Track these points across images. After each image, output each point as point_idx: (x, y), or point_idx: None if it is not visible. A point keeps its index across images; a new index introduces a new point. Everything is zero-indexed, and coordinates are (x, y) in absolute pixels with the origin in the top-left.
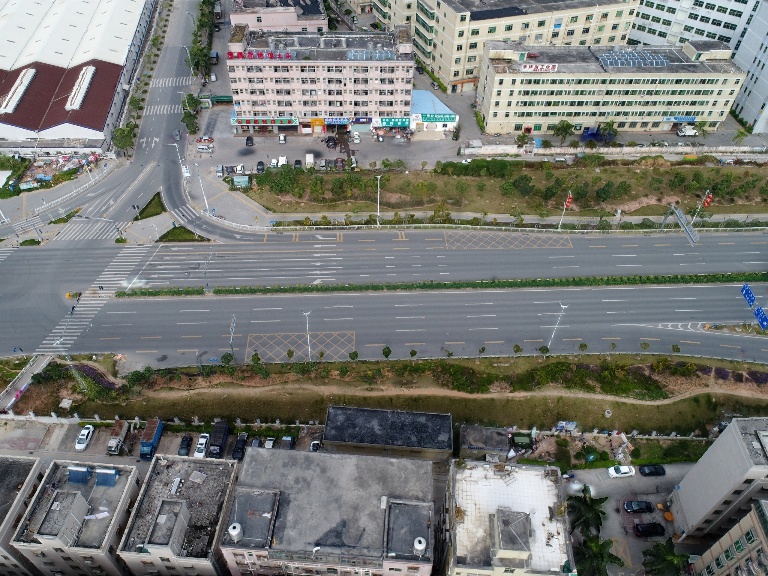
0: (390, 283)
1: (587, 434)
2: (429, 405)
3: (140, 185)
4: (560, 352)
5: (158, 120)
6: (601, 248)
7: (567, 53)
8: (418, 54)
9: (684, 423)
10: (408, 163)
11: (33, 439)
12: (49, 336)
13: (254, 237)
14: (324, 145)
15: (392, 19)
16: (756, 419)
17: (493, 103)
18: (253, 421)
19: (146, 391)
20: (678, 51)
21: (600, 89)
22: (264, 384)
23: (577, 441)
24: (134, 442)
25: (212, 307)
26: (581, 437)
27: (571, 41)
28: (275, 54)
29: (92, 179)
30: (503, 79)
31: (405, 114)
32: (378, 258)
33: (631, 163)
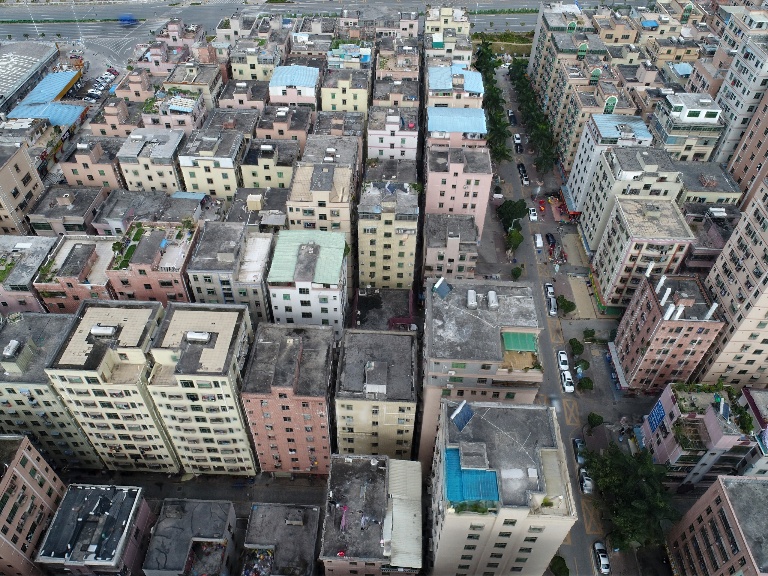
0: None
1: None
2: None
3: None
4: None
5: None
6: (508, 3)
7: None
8: None
9: None
10: None
11: None
12: None
13: (317, 2)
14: None
15: None
16: None
17: None
18: None
19: None
20: None
21: None
22: None
23: None
24: None
25: None
26: None
27: None
28: None
29: None
30: None
31: None
32: None
33: None
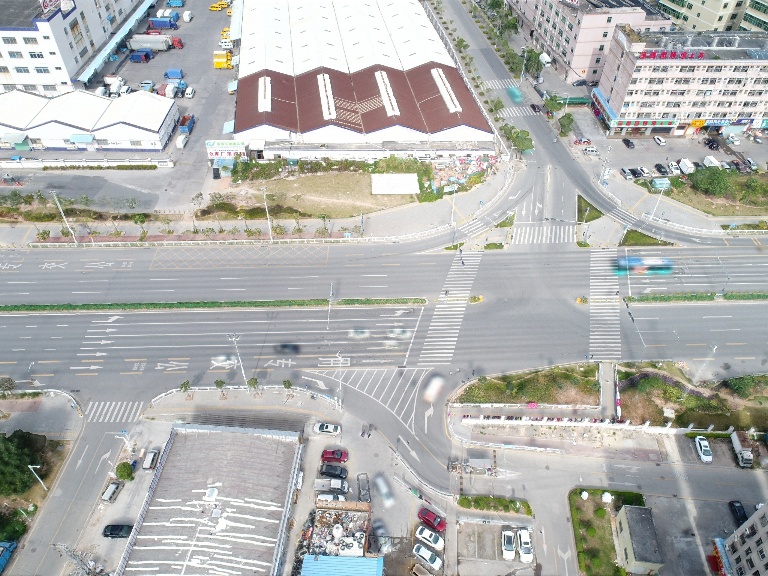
0: None
1: None
2: None
3: (553, 188)
4: None
5: (518, 122)
6: None
7: None
8: None
9: None
10: None
11: (650, 450)
12: (591, 342)
13: (714, 241)
14: (706, 147)
15: (690, 19)
16: None
17: None
18: None
19: (740, 401)
20: None
21: None
22: None
23: None
24: None
25: (732, 313)
26: None
27: None
28: (678, 54)
29: (507, 182)
30: None
31: None
32: None
33: None
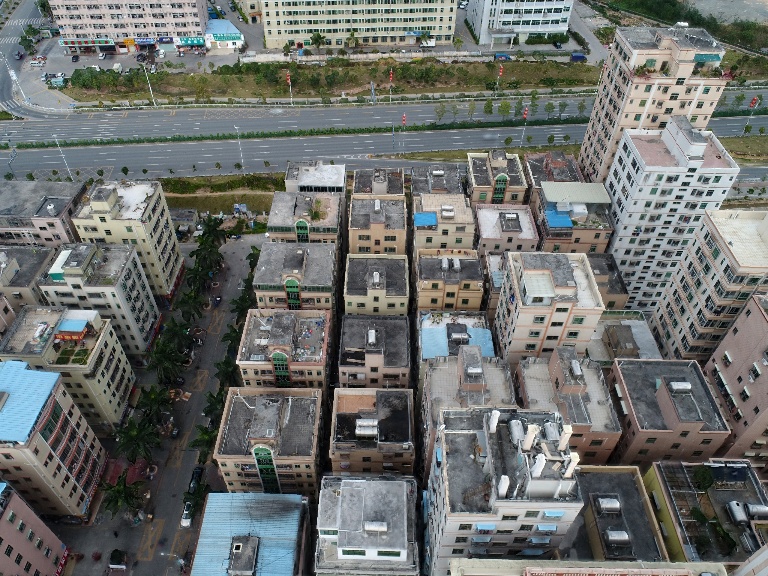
0: (148, 137)
1: (259, 216)
2: None
3: None
4: None
5: (5, 47)
6: (320, 116)
7: None
8: None
9: None
10: (197, 69)
11: None
12: None
13: (59, 116)
14: (135, 60)
15: None
16: (303, 162)
17: (265, 22)
18: None
19: None
20: None
21: (347, 9)
22: None
23: (252, 221)
24: None
25: None
26: (256, 218)
27: None
28: None
29: None
30: (267, 2)
31: (198, 34)
32: (149, 126)
33: (370, 64)
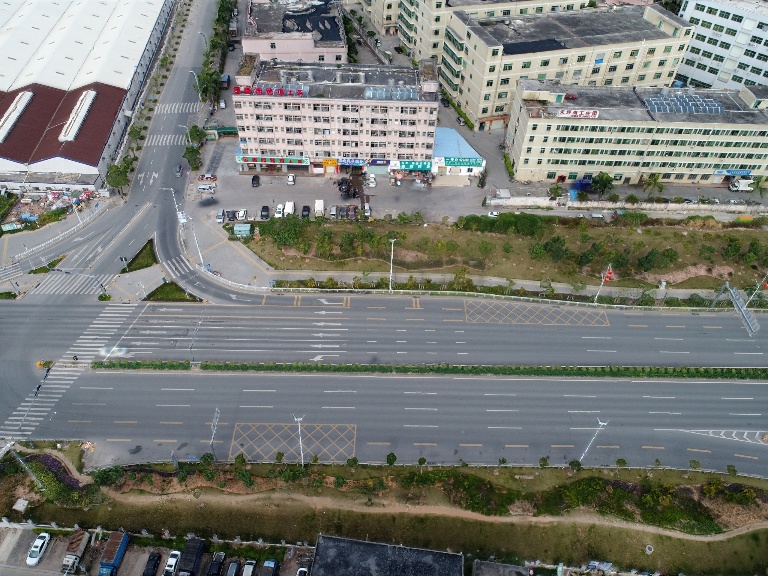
0: (400, 365)
1: (623, 574)
2: (438, 527)
3: (132, 229)
4: (593, 463)
5: (159, 152)
6: (642, 328)
7: (609, 95)
8: (444, 85)
9: (740, 566)
10: (427, 213)
11: None
12: (12, 415)
13: (251, 298)
14: (336, 188)
15: (418, 44)
16: None
17: (524, 149)
18: (232, 537)
19: (113, 493)
20: (734, 96)
21: (645, 138)
22: (248, 491)
23: None
24: (94, 558)
25: (197, 386)
26: None
27: (613, 77)
28: (286, 89)
29: (81, 221)
30: (537, 124)
31: (426, 157)
32: (388, 331)
33: (677, 223)
